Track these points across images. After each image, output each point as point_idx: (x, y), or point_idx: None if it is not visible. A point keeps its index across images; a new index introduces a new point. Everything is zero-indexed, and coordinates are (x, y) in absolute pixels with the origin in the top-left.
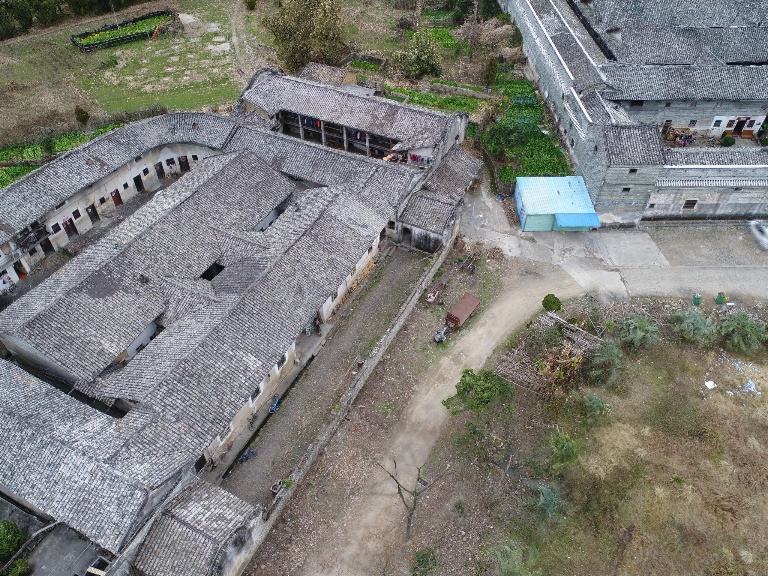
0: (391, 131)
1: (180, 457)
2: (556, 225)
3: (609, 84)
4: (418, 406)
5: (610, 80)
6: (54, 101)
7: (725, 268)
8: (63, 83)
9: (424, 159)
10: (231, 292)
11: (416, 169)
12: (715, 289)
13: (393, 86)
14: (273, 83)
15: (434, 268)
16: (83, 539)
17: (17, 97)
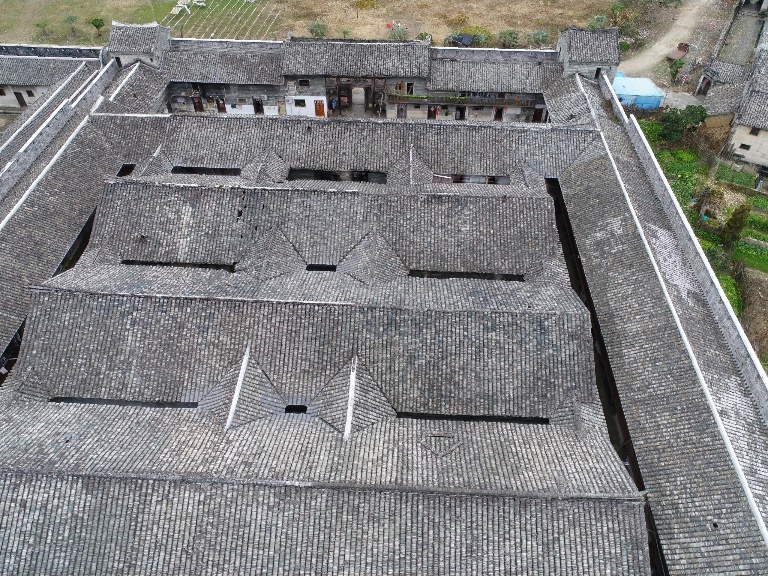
0: None
1: None
2: None
3: None
4: None
5: None
6: None
7: None
8: None
9: None
10: None
11: None
12: None
13: None
14: None
15: None
16: None
17: None
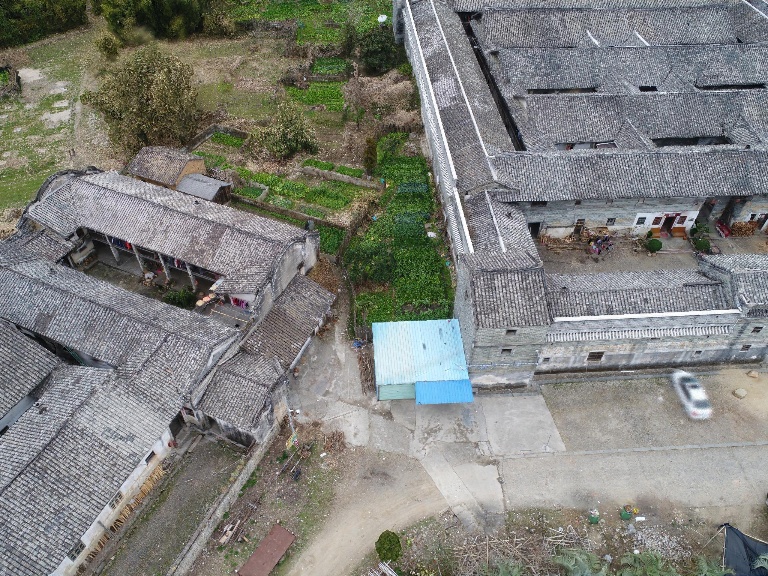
0: (212, 261)
1: None
2: None
3: (501, 183)
4: None
5: (503, 176)
6: None
7: (638, 453)
8: None
9: (249, 304)
10: None
11: (229, 327)
12: (622, 491)
13: (256, 169)
14: (75, 189)
15: (241, 479)
16: None
17: None
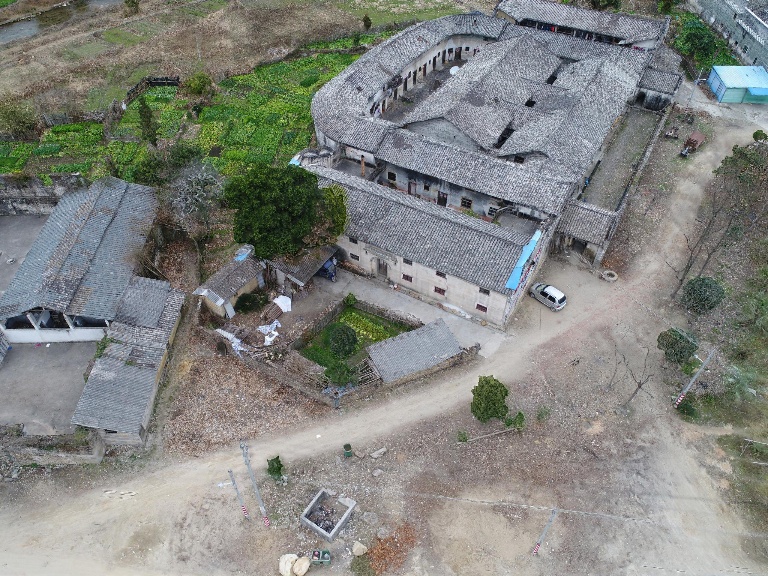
0: (615, 32)
1: (571, 179)
2: (746, 98)
3: None
4: (682, 187)
5: None
6: (328, 17)
7: None
8: (327, 6)
9: None
10: (558, 109)
11: None
12: None
13: None
14: None
15: None
16: (522, 218)
17: (298, 14)
